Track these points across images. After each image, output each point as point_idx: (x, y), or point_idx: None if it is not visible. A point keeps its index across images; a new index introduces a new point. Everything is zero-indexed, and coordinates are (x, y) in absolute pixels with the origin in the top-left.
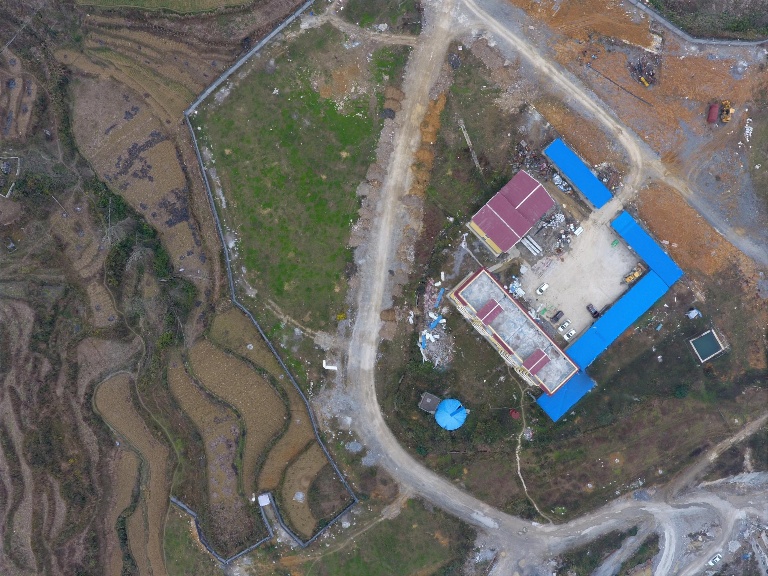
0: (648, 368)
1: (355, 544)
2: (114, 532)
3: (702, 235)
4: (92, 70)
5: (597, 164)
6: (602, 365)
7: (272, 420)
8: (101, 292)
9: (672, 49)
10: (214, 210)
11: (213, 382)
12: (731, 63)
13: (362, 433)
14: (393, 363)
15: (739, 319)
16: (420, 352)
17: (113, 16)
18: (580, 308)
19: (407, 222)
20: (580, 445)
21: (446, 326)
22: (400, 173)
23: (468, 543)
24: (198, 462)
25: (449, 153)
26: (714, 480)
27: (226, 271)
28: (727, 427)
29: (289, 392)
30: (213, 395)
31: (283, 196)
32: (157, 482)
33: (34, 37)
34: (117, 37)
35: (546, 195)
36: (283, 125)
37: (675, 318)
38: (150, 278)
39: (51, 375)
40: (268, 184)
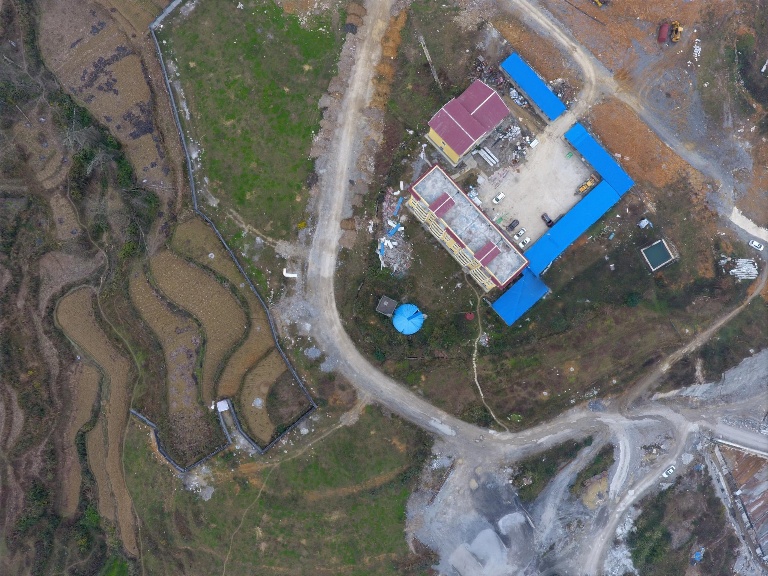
0: (601, 276)
1: (313, 450)
2: (73, 447)
3: (653, 149)
4: None
5: (552, 80)
6: (556, 273)
7: (233, 329)
8: (64, 204)
9: None
10: (178, 121)
11: (174, 291)
12: None
13: (321, 339)
14: (353, 271)
15: (688, 230)
16: (379, 258)
17: None
18: (535, 218)
19: (367, 133)
20: (535, 352)
21: (404, 234)
22: (361, 86)
23: (425, 450)
24: (158, 373)
25: (409, 68)
26: (667, 392)
27: (189, 181)
28: (678, 337)
29: (250, 300)
30: (174, 304)
31: (246, 107)
32: (118, 396)
33: None
34: None
35: (501, 103)
36: (247, 38)
37: (627, 228)
38: (114, 192)
39: (12, 286)
40: (231, 96)
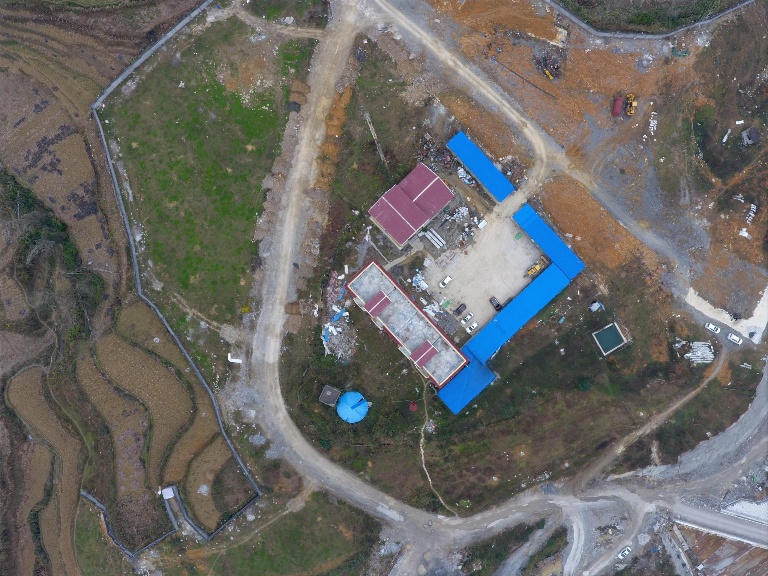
0: (550, 361)
1: (260, 537)
2: (26, 526)
3: (606, 228)
4: (1, 63)
5: (502, 157)
6: (504, 358)
7: (179, 413)
8: (11, 286)
9: (577, 42)
10: (120, 203)
11: (120, 375)
12: (636, 56)
13: (266, 426)
14: (298, 356)
15: (642, 312)
16: (323, 345)
17: (18, 9)
18: (483, 301)
19: (312, 215)
20: (484, 438)
21: (349, 319)
22: (305, 166)
23: (373, 536)
24: (107, 455)
25: (355, 146)
26: (622, 473)
27: (133, 264)
28: (632, 420)
29: (195, 385)
30: (120, 388)
31: (189, 189)
32: (69, 476)
33: None
34: (23, 30)
35: (444, 188)
36: (189, 118)
37: (578, 311)
38: (61, 272)
39: None
40: (174, 177)
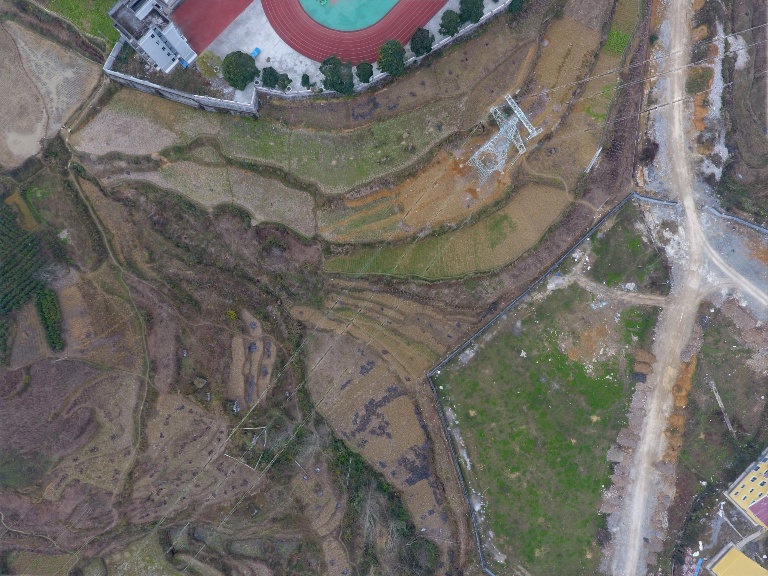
0: None
1: None
2: None
3: None
4: (328, 326)
5: None
6: None
7: None
8: (336, 547)
9: None
10: None
11: None
12: None
13: None
14: None
15: None
16: None
17: (358, 281)
18: None
19: (662, 489)
20: None
21: None
22: (653, 438)
23: None
24: None
25: (701, 416)
26: None
27: (473, 535)
28: None
29: None
30: None
31: (532, 461)
32: None
33: (270, 295)
34: (359, 299)
35: None
36: (531, 388)
37: None
38: (383, 529)
39: None
40: (516, 448)
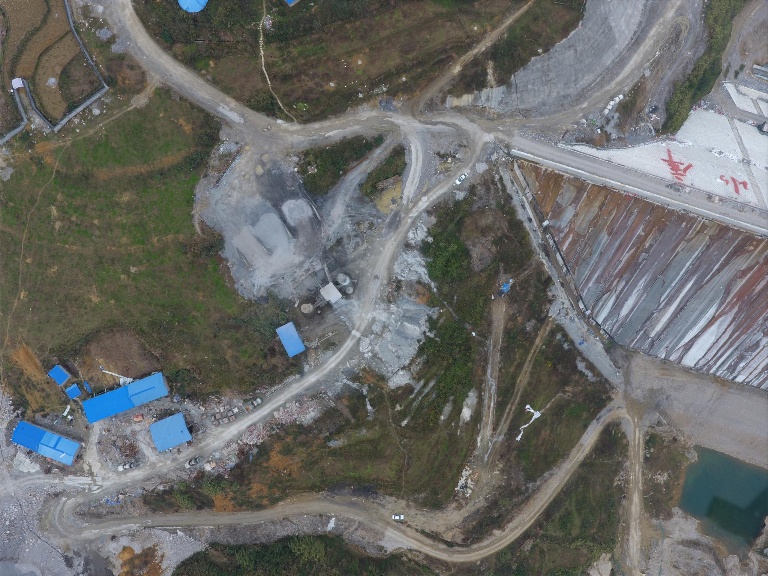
0: None
1: (104, 130)
2: None
3: None
4: None
5: None
6: None
7: (35, 18)
8: None
9: None
10: None
11: None
12: None
13: (113, 22)
14: None
15: None
16: None
17: None
18: None
19: None
20: (322, 41)
21: None
22: None
23: (212, 133)
24: None
25: None
26: (460, 96)
27: None
28: (466, 33)
29: None
30: None
31: None
32: None
33: None
34: None
35: None
36: None
37: None
38: None
39: None
40: None
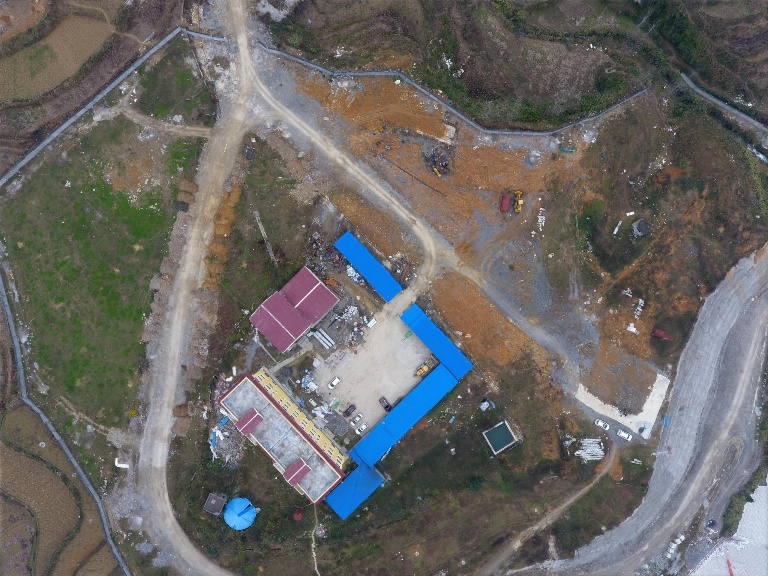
0: (441, 461)
1: None
2: None
3: (496, 325)
4: None
5: (391, 255)
6: (395, 459)
7: (66, 519)
8: None
9: (466, 139)
10: (5, 305)
11: (5, 481)
12: (524, 153)
13: (153, 533)
14: (187, 460)
15: (532, 409)
16: (210, 450)
17: None
18: (373, 401)
19: (200, 316)
20: (377, 540)
21: None
22: (193, 266)
23: None
24: None
25: (244, 245)
26: (521, 568)
27: None
28: (527, 517)
29: (82, 491)
30: (5, 494)
31: (75, 290)
32: None
33: None
34: None
35: (327, 292)
36: (75, 218)
37: (468, 410)
38: None
39: None
40: (60, 278)
